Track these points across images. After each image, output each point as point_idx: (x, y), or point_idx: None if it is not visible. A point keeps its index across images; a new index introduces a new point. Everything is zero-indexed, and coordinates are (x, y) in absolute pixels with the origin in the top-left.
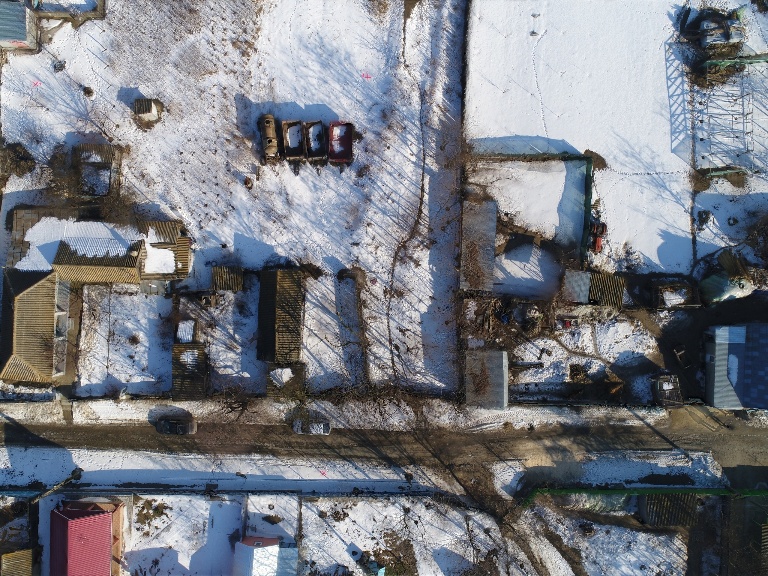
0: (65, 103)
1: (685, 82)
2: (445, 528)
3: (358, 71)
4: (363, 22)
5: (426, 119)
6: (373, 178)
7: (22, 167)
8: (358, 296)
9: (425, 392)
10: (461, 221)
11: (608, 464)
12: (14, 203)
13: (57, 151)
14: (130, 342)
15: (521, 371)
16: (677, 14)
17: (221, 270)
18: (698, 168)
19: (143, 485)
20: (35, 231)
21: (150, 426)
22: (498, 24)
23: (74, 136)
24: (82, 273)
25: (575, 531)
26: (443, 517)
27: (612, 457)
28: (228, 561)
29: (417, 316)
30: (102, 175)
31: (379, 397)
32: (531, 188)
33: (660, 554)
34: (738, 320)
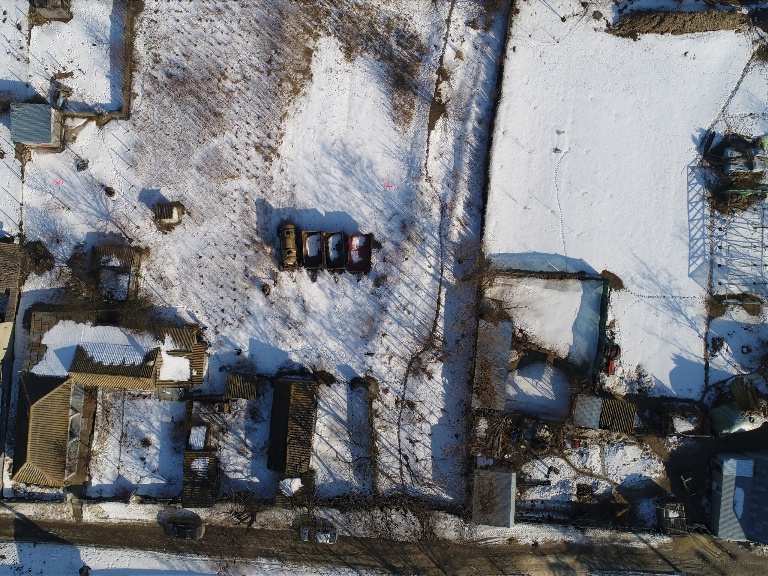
0: (86, 202)
1: (706, 207)
2: None
3: (380, 180)
4: (387, 131)
5: (446, 232)
6: (390, 289)
7: (41, 265)
8: (370, 406)
9: (432, 503)
10: (476, 336)
11: None
12: (32, 302)
13: (77, 251)
14: (142, 444)
15: (528, 488)
16: (701, 138)
17: (235, 378)
18: (714, 294)
19: None
20: (52, 334)
21: (158, 526)
22: (522, 139)
23: (94, 236)
24: (98, 380)
25: None
26: None
27: None
28: None
29: (427, 428)
30: (121, 280)
31: (386, 506)
32: (547, 306)
33: None
34: (746, 448)
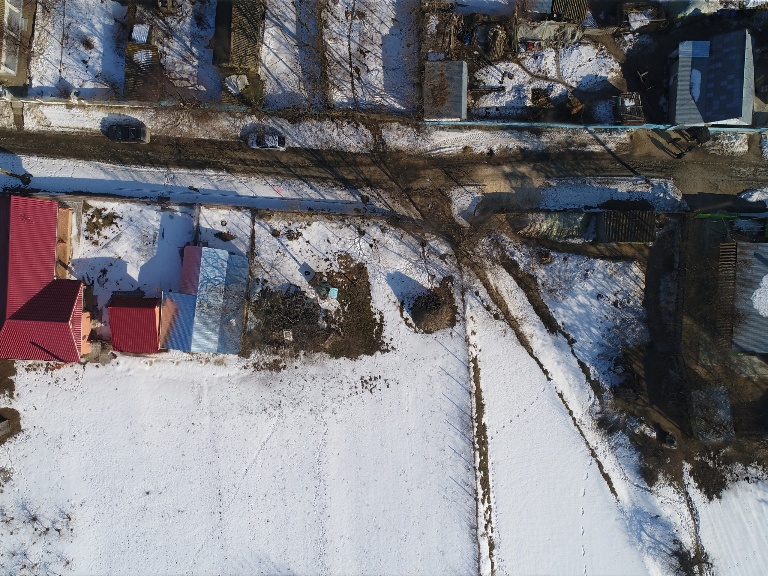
0: None
1: None
2: (400, 252)
3: None
4: None
5: None
6: None
7: None
8: (319, 14)
9: (384, 115)
10: None
11: (567, 190)
12: None
13: None
14: (84, 46)
15: (482, 95)
16: None
17: None
18: None
19: (93, 194)
20: None
21: (102, 136)
22: None
23: None
24: None
25: (532, 258)
26: (399, 241)
27: (572, 183)
28: (178, 275)
29: (378, 38)
30: None
31: (337, 118)
32: None
33: (617, 282)
34: None
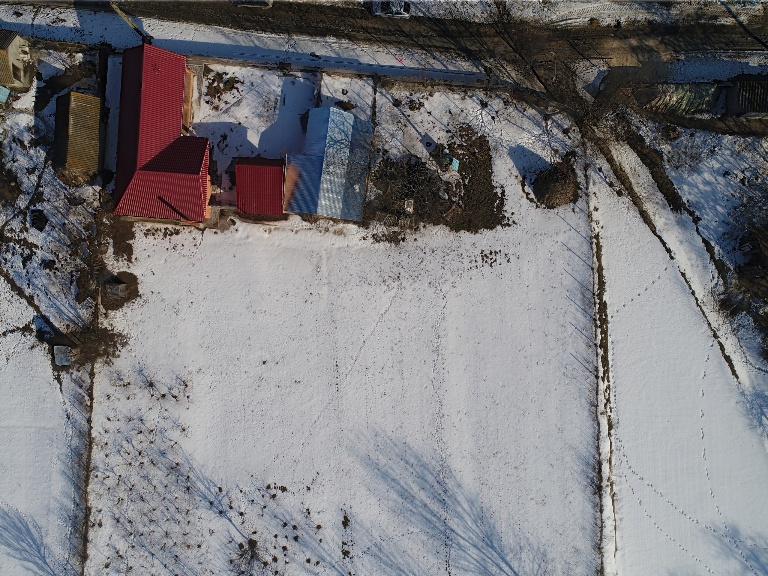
0: None
1: None
2: (523, 125)
3: None
4: None
5: None
6: None
7: None
8: None
9: None
10: None
11: (696, 63)
12: None
13: None
14: None
15: None
16: None
17: None
18: None
19: None
20: None
21: (224, 0)
22: None
23: None
24: None
25: (658, 133)
26: (521, 115)
27: (701, 56)
28: (298, 142)
29: None
30: None
31: None
32: None
33: (745, 159)
34: None
